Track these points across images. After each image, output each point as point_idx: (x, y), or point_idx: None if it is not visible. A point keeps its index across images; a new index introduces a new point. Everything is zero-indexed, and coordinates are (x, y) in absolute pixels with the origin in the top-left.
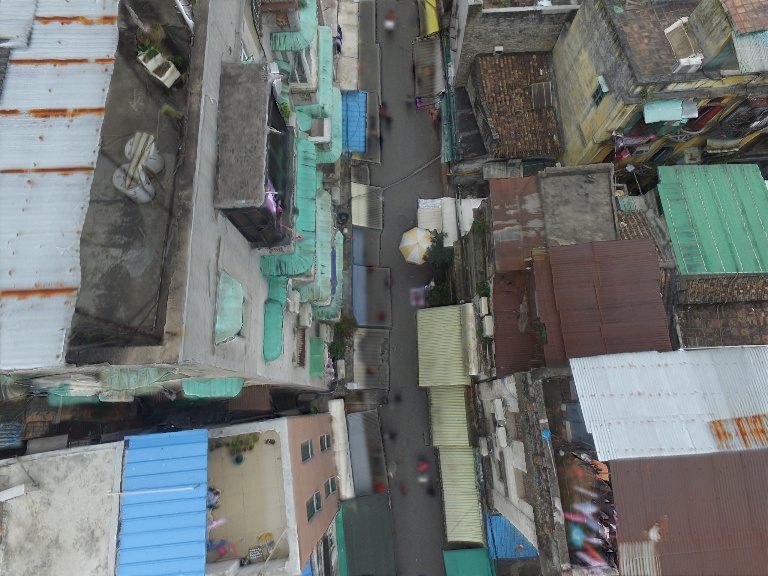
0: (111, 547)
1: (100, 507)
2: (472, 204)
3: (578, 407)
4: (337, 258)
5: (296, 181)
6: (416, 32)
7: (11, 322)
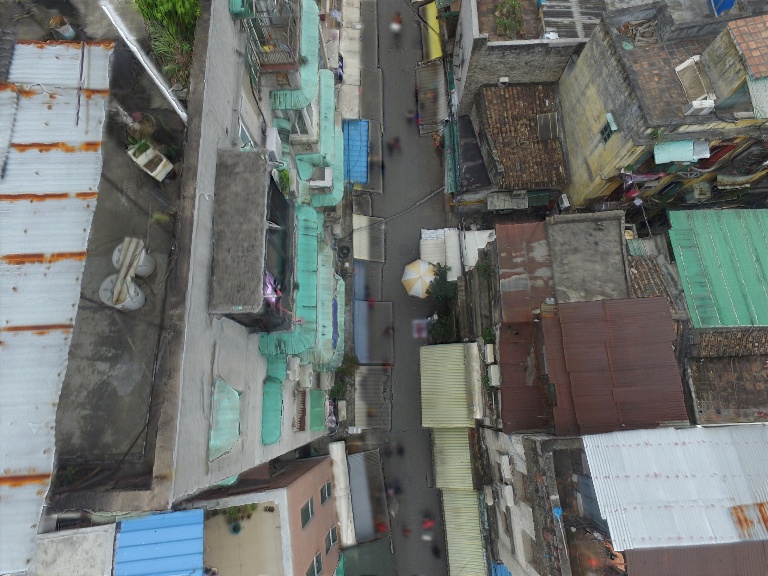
0: None
1: None
2: (476, 237)
3: (591, 483)
4: (338, 307)
5: (296, 253)
6: (419, 55)
7: None
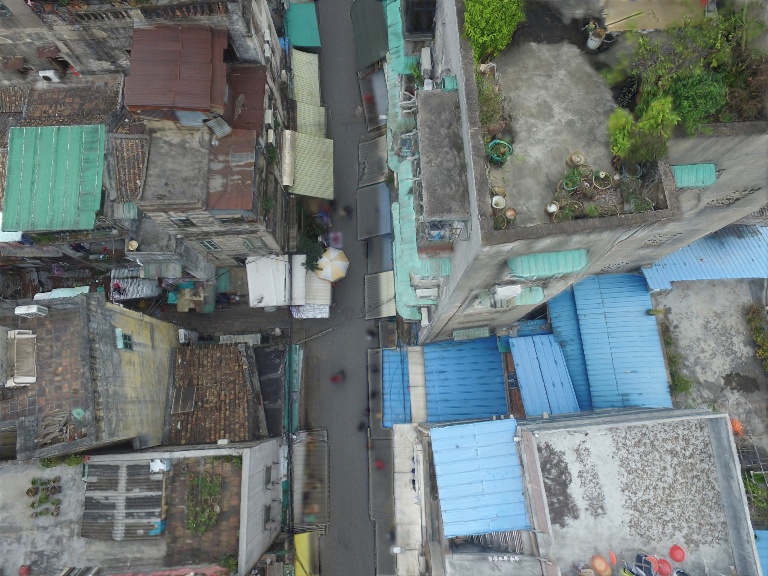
0: None
1: None
2: (275, 297)
3: None
4: None
5: None
6: (326, 575)
7: None
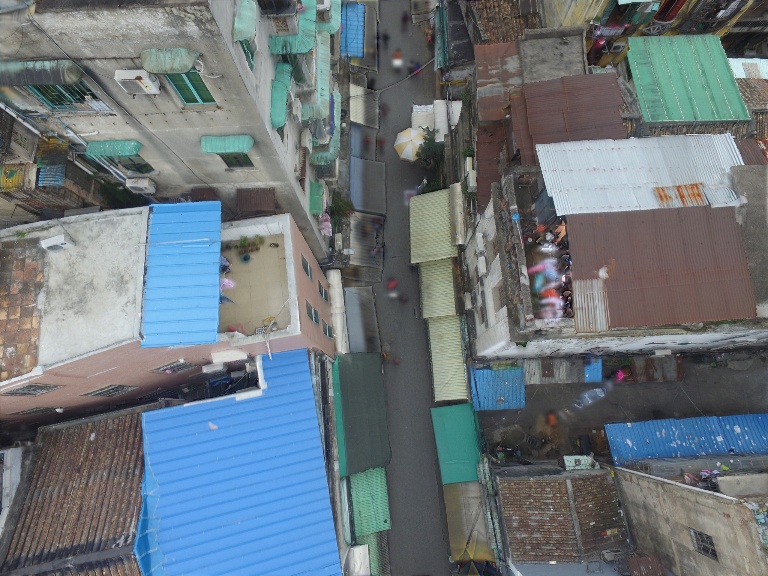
0: (139, 285)
1: (128, 258)
2: None
3: (544, 194)
4: (335, 112)
5: None
6: None
7: None
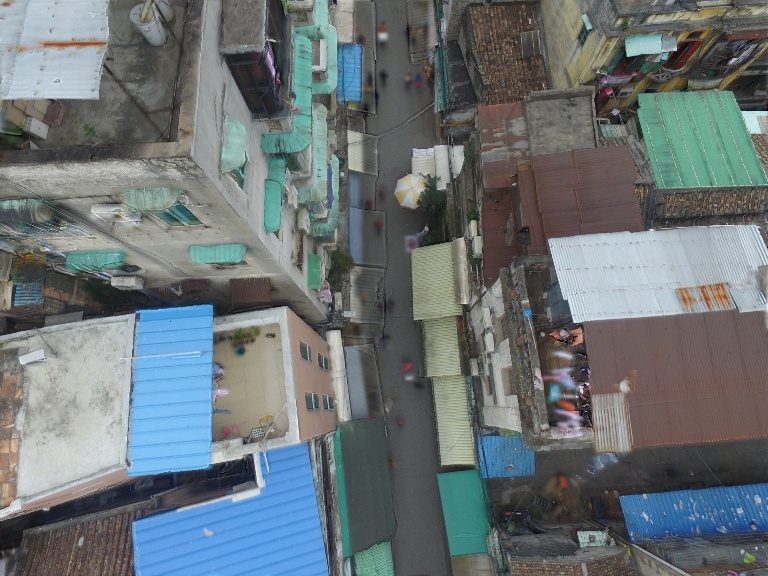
0: (125, 404)
1: (114, 372)
2: None
3: (557, 288)
4: (333, 180)
5: (293, 70)
6: None
7: (53, 67)
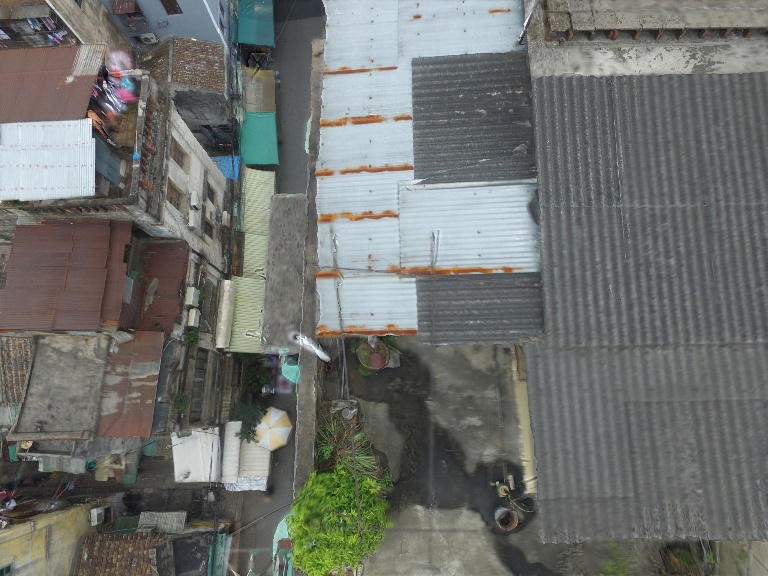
0: None
1: None
2: (203, 473)
3: (105, 173)
4: None
5: None
6: None
7: None
